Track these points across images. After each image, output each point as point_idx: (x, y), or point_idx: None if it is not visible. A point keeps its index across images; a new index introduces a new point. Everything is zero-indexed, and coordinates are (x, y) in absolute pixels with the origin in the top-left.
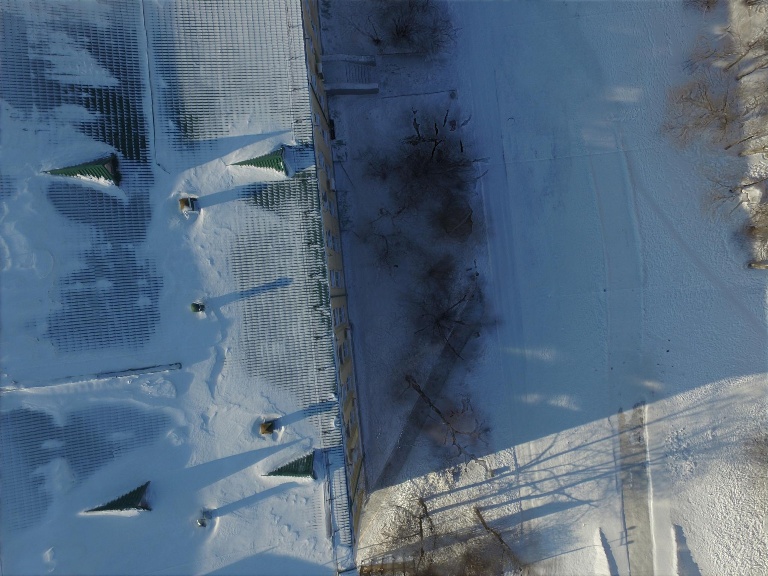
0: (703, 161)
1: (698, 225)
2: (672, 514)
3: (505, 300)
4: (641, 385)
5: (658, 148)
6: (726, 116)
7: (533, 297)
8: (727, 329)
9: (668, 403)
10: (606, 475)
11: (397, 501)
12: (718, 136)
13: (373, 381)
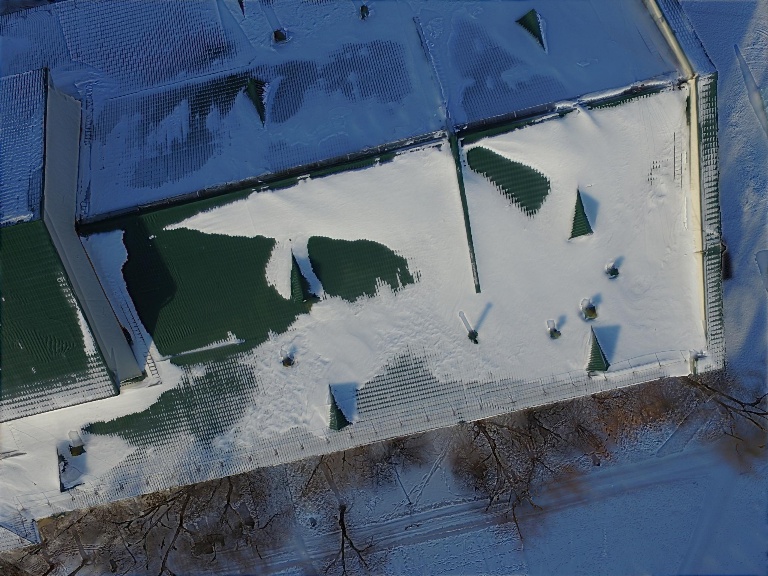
0: None
1: None
2: None
3: None
4: None
5: None
6: None
7: None
8: None
9: None
10: None
11: None
12: None
13: None
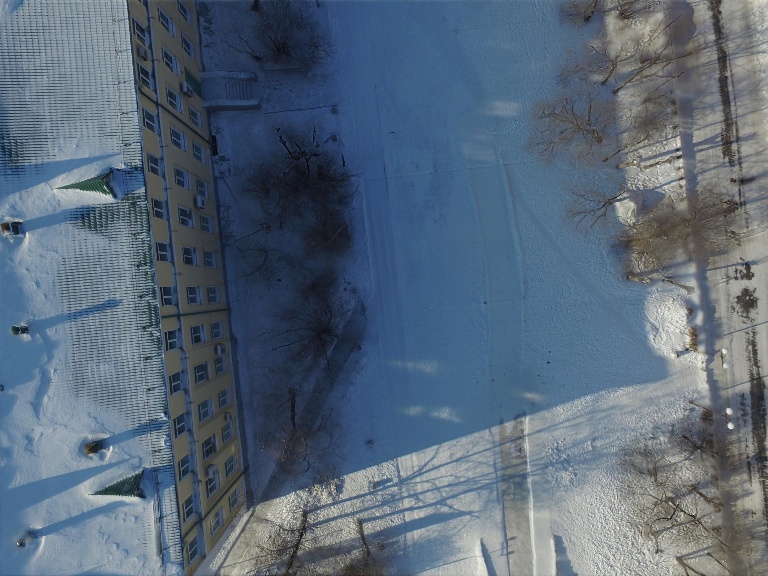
0: (582, 174)
1: (577, 237)
2: (552, 524)
3: (387, 313)
4: (521, 396)
5: (537, 161)
6: (595, 130)
7: (415, 310)
8: (607, 340)
9: (549, 414)
10: (487, 486)
11: (282, 513)
12: (582, 150)
13: (257, 394)
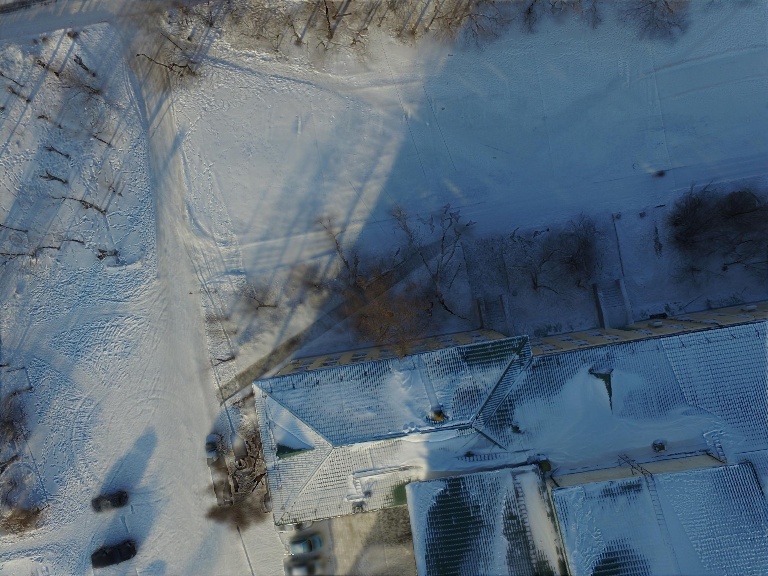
0: None
1: (713, 6)
2: None
3: None
4: None
5: (651, 44)
6: None
7: None
8: None
9: None
10: None
11: None
12: None
13: None
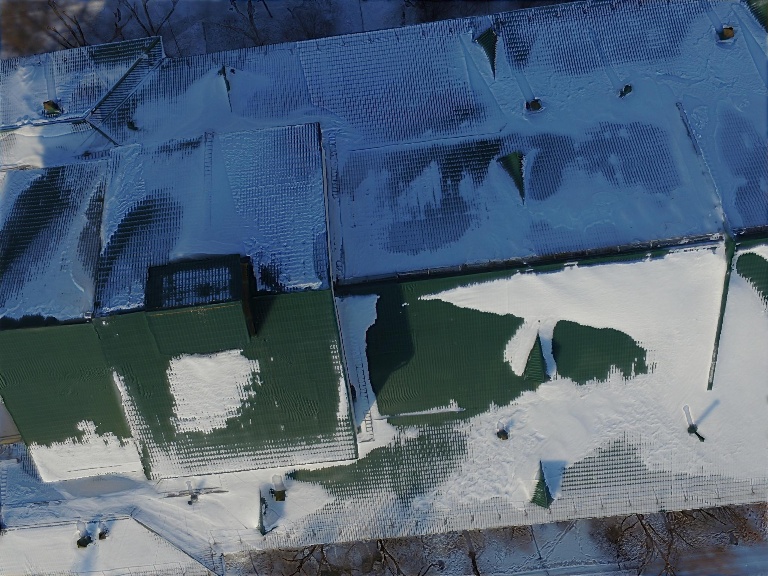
0: None
1: None
2: None
3: None
4: None
5: None
6: None
7: None
8: None
9: None
10: None
11: None
12: None
13: None
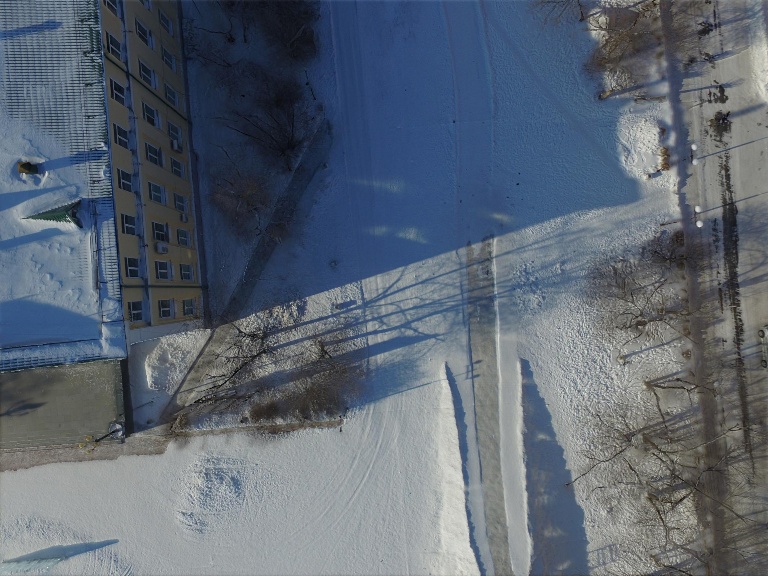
0: None
1: (549, 56)
2: (519, 348)
3: (353, 131)
4: (490, 217)
5: None
6: None
7: (382, 129)
8: (578, 162)
9: (517, 236)
10: (453, 308)
11: (241, 336)
12: None
13: (218, 213)
